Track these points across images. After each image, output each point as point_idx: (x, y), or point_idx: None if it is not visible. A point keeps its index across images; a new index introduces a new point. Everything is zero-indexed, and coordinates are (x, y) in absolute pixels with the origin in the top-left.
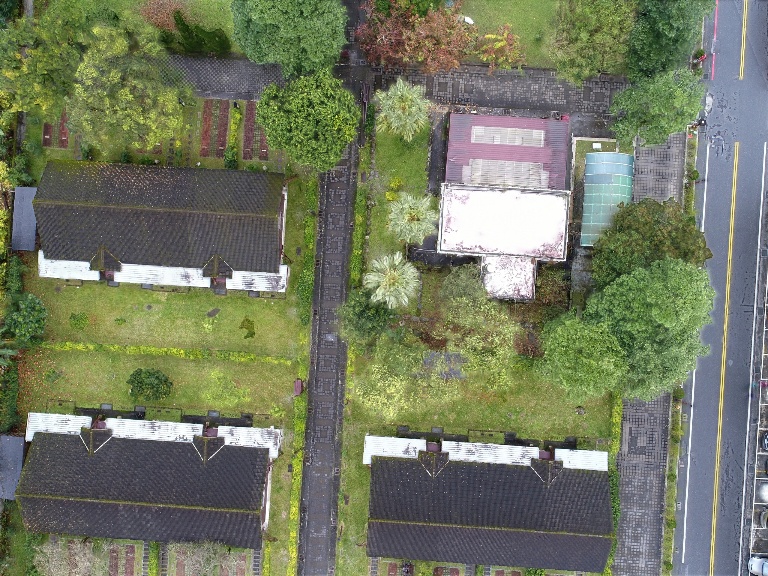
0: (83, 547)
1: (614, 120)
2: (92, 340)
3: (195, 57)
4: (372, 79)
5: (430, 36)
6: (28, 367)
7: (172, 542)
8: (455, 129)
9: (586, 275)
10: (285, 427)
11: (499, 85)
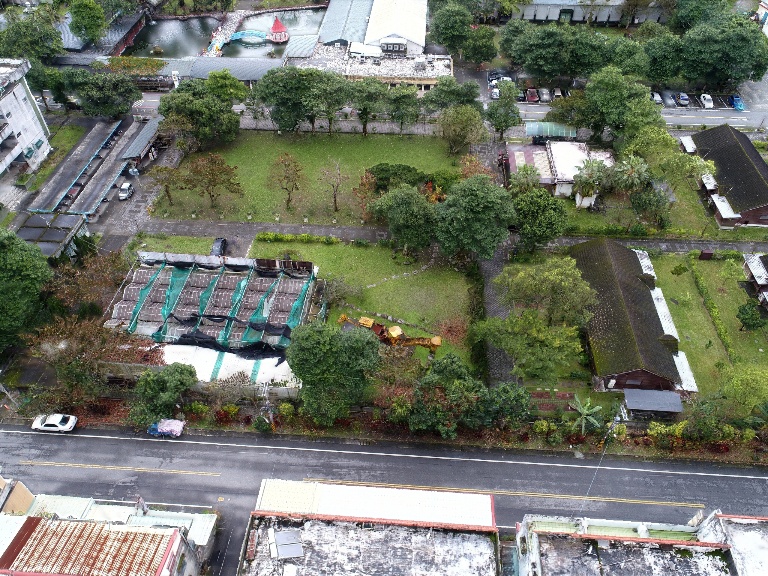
0: None
1: (495, 144)
2: None
3: (485, 313)
4: None
5: None
6: None
7: None
8: None
9: None
10: None
11: None
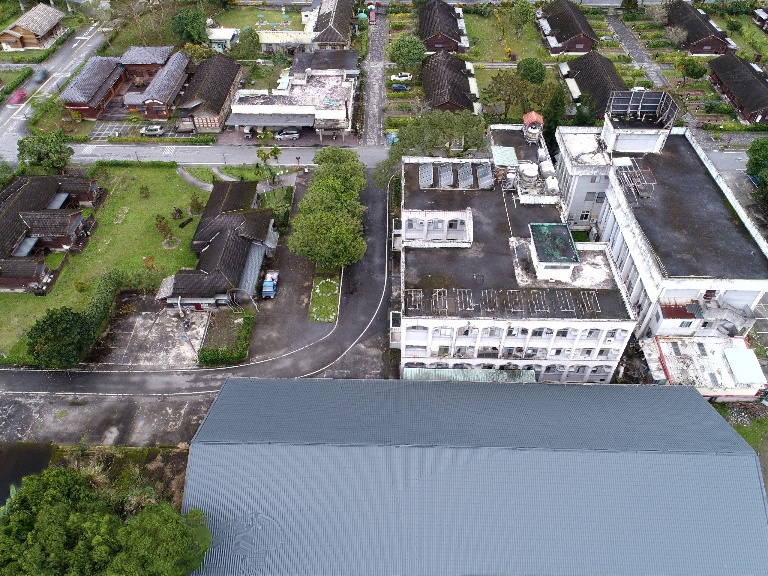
0: None
1: None
2: None
3: None
4: None
5: None
6: (711, 16)
7: None
8: None
9: None
10: None
11: None
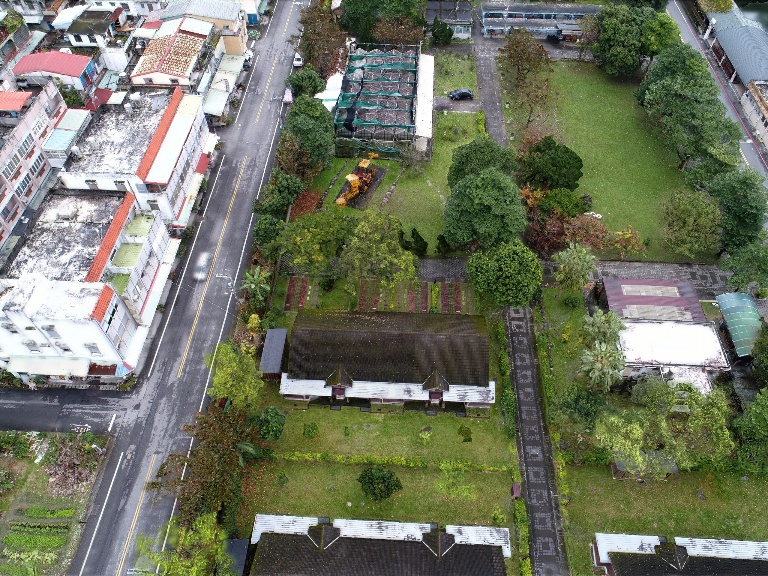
0: None
1: (721, 291)
2: None
3: None
4: None
5: (581, 228)
6: (251, 481)
7: None
8: (609, 287)
9: (748, 392)
10: None
11: (627, 271)
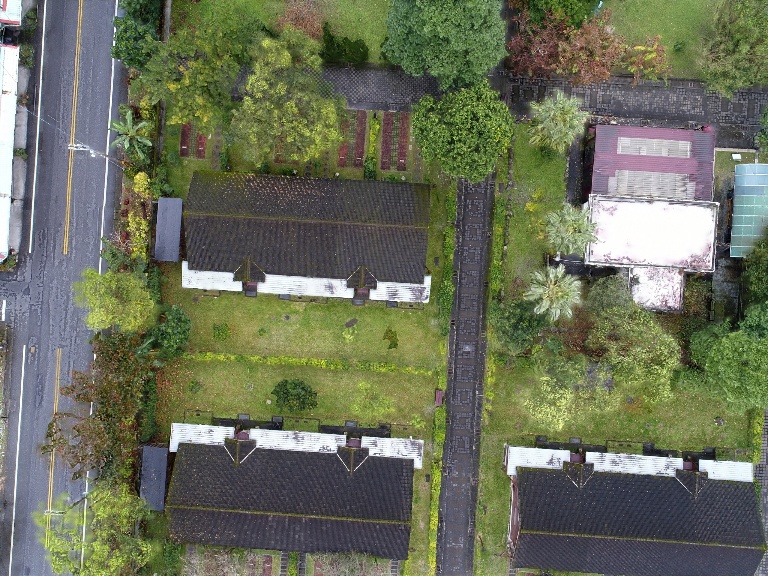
0: (231, 558)
1: (752, 131)
2: (230, 350)
3: (332, 67)
4: (510, 89)
5: (584, 48)
6: (166, 377)
7: (318, 553)
8: (601, 140)
9: (727, 286)
10: (423, 437)
11: (637, 96)
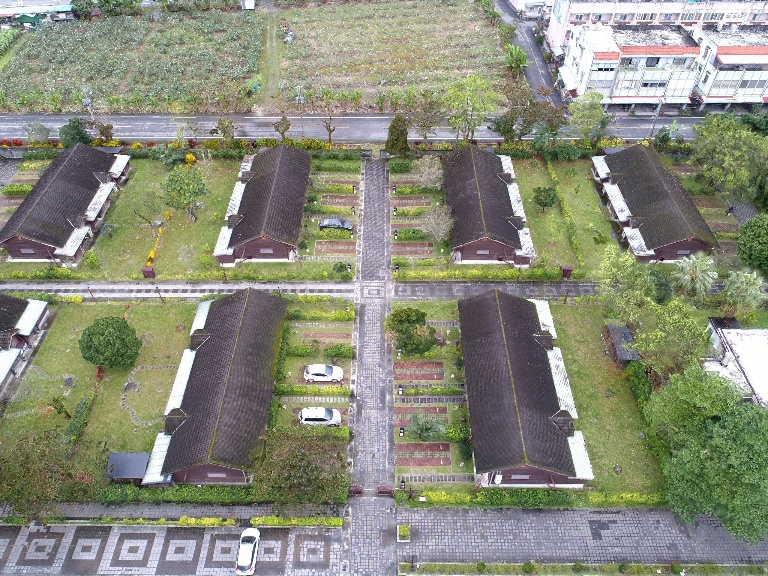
0: None
1: None
2: None
3: None
4: None
5: None
6: None
7: None
8: None
9: None
10: None
11: None
